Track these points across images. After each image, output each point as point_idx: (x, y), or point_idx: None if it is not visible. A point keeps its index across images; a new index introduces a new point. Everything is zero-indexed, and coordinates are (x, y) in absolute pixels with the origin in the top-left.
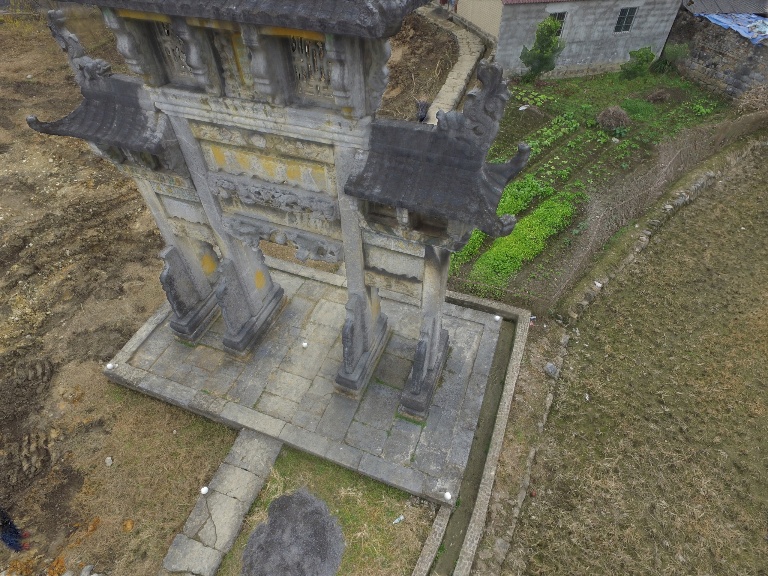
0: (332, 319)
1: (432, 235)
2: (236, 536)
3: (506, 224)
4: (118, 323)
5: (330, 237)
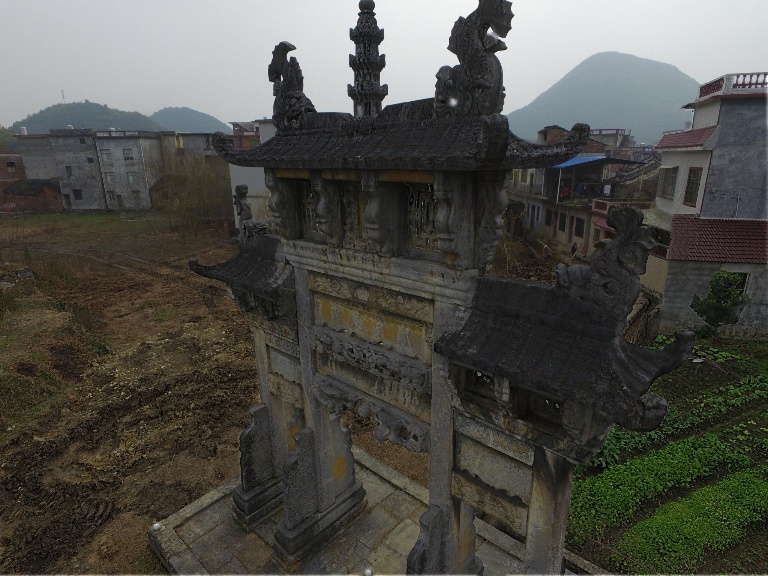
0: None
1: (543, 430)
2: None
3: (650, 406)
4: (193, 483)
5: (418, 417)
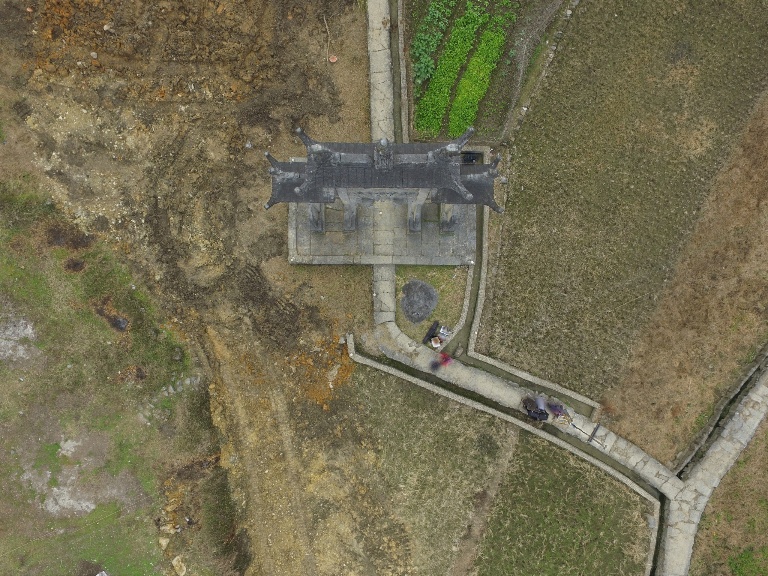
0: None
1: None
2: (396, 305)
3: None
4: (268, 232)
5: None
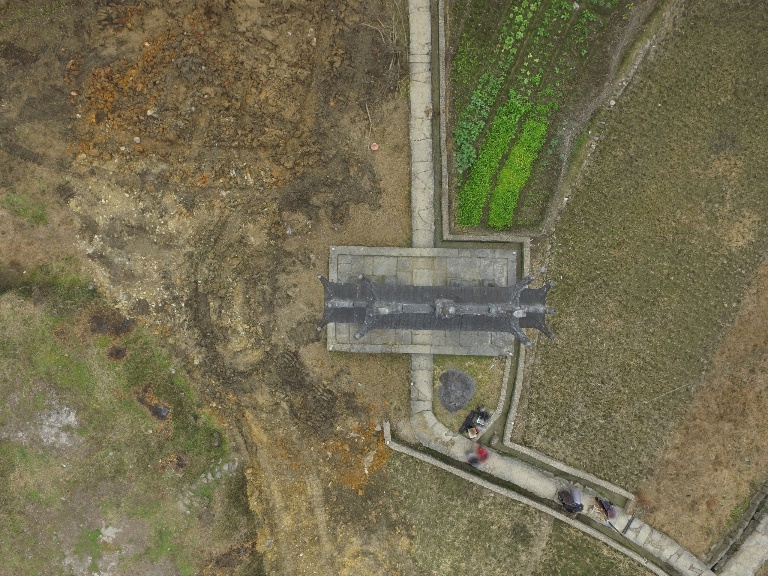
0: (426, 281)
1: None
2: (433, 394)
3: None
4: (307, 319)
5: None
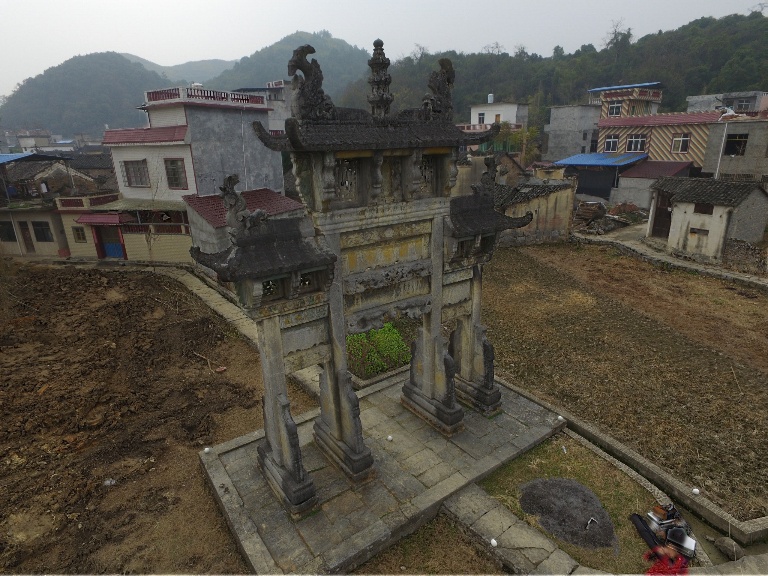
0: (376, 418)
1: (479, 256)
2: None
3: None
4: None
5: (421, 295)
